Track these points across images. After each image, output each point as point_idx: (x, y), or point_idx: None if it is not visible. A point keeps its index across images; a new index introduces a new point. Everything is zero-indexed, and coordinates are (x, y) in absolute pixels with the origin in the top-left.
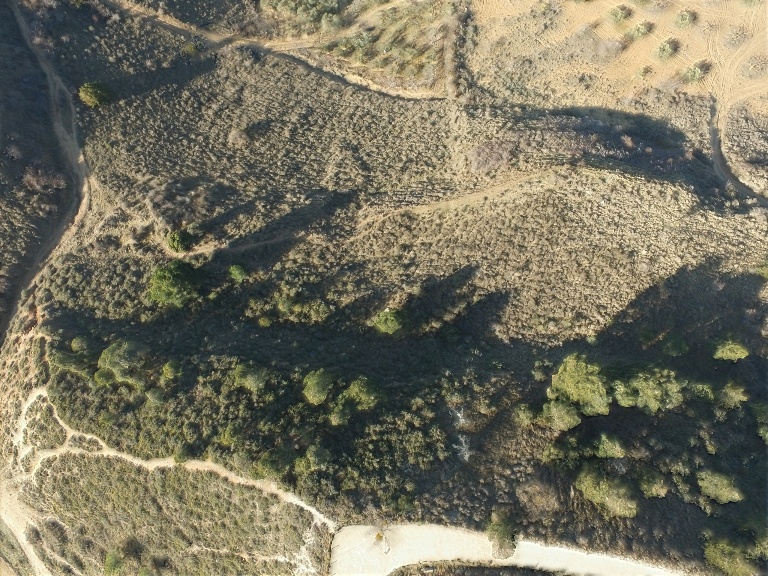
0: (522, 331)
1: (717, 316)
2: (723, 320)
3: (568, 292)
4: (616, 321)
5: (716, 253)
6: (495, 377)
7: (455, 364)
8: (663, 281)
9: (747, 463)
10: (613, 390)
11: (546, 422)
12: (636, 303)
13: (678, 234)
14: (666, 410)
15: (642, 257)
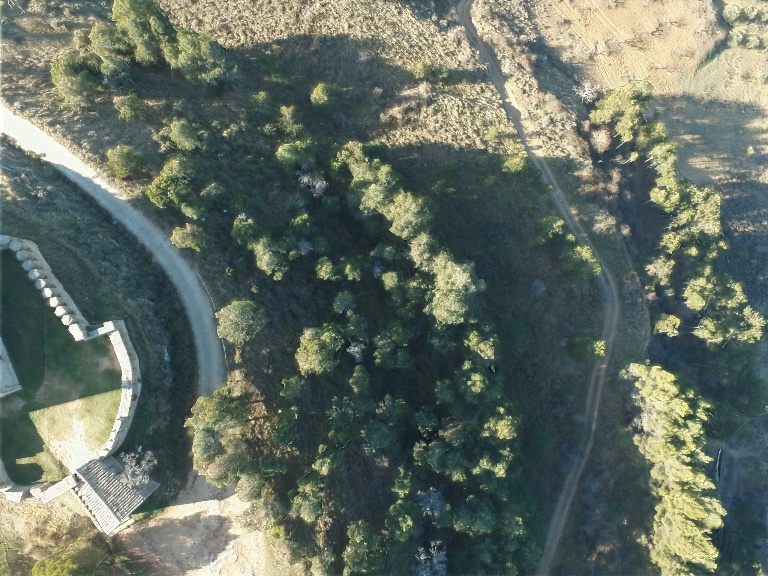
0: (164, 15)
1: (351, 86)
2: (355, 92)
3: (228, 5)
4: (256, 47)
5: (387, 40)
6: (94, 16)
7: (75, 2)
8: (319, 35)
9: (251, 157)
10: (150, 25)
11: (94, 48)
12: (284, 42)
13: (362, 8)
14: (203, 80)
15: (314, 8)
